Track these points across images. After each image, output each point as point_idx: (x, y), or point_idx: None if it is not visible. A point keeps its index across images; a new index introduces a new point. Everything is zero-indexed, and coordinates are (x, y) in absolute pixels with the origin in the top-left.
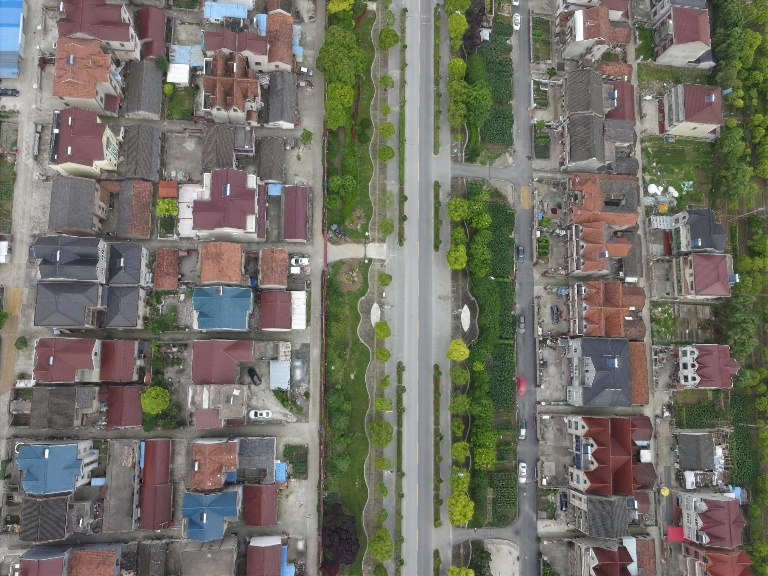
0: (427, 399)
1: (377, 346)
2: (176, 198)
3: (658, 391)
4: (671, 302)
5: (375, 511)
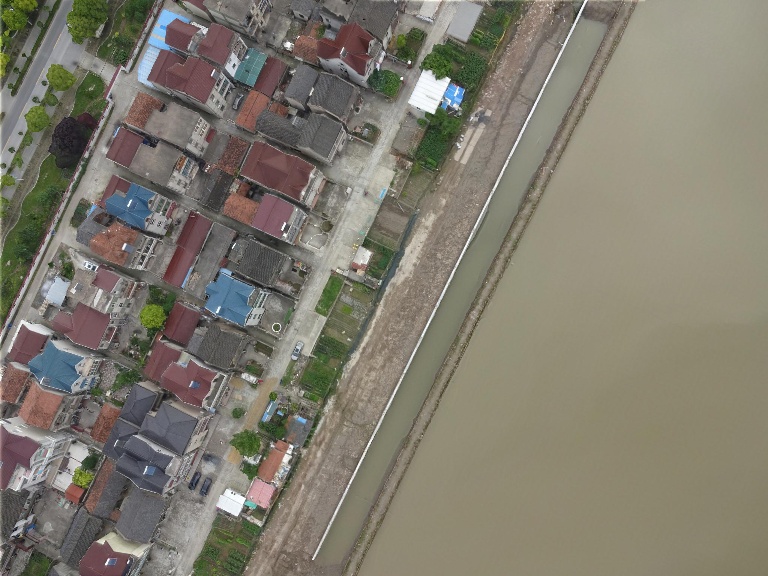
0: None
1: None
2: None
3: None
4: None
5: (43, 148)
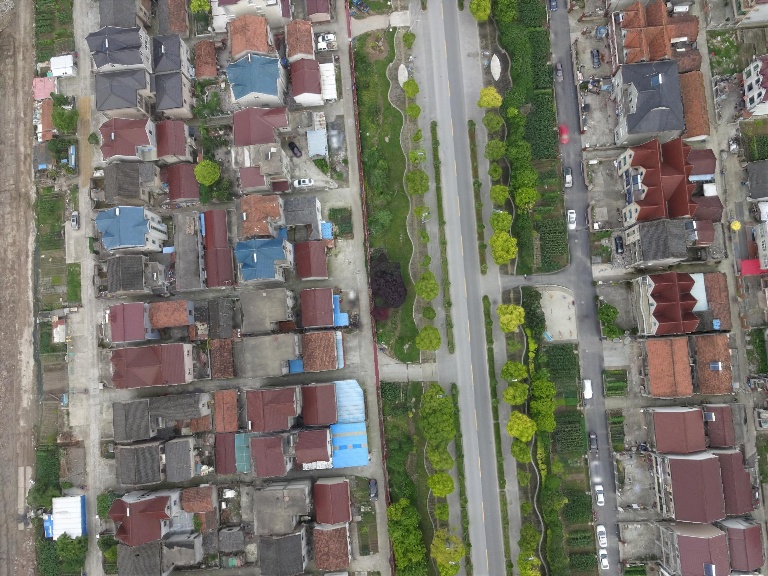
0: (464, 154)
1: None
2: None
3: (722, 124)
4: (732, 29)
5: (421, 263)
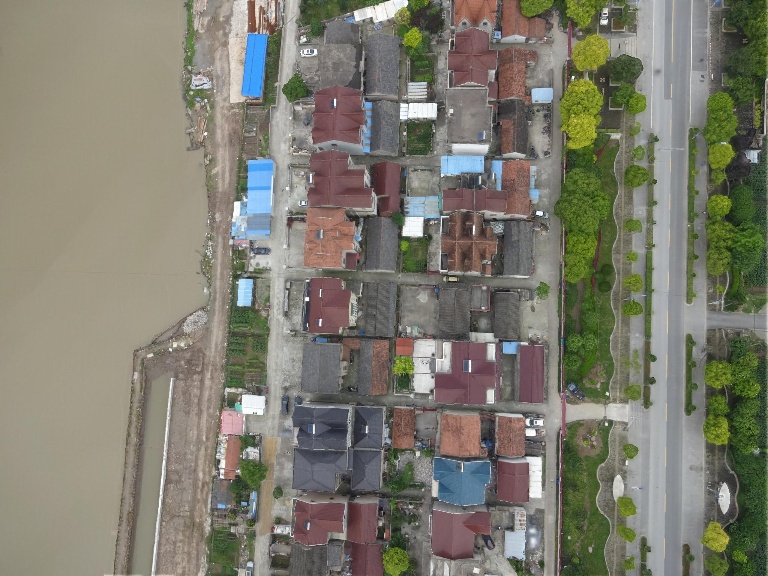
0: None
1: (618, 518)
2: (411, 354)
3: None
4: None
5: None
